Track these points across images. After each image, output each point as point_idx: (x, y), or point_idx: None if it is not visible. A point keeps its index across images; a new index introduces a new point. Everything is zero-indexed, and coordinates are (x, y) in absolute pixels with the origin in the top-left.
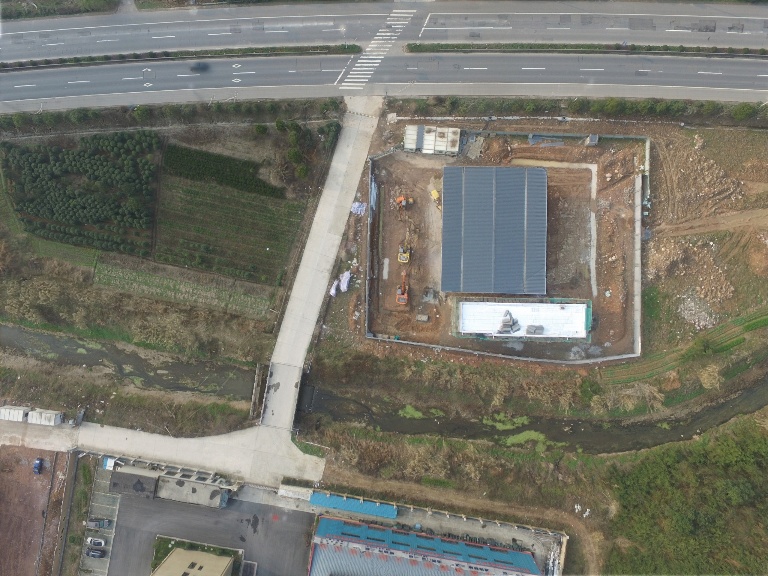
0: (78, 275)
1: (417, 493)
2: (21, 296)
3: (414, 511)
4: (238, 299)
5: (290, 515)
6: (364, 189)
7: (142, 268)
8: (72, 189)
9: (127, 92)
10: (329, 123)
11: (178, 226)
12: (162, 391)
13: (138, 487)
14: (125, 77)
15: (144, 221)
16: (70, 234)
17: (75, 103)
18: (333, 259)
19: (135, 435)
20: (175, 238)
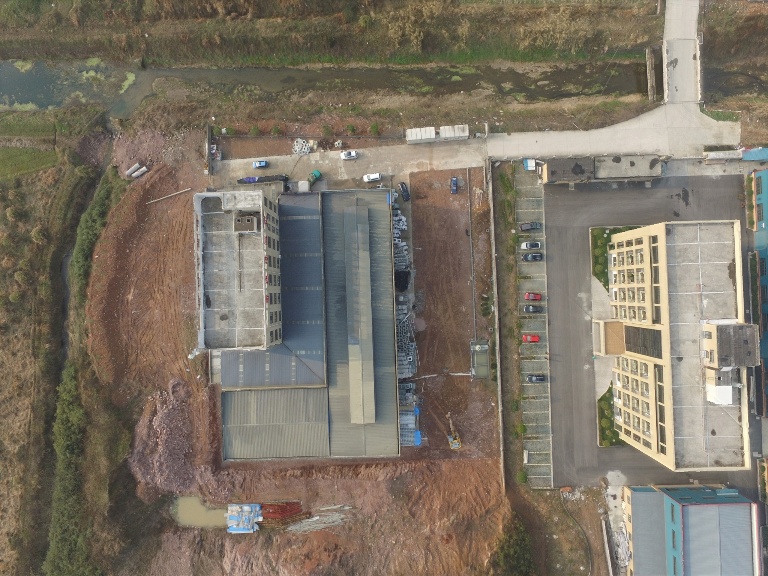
0: None
1: None
2: (400, 20)
3: None
4: None
5: (719, 181)
6: None
7: None
8: None
9: None
10: None
11: None
12: (547, 102)
13: (577, 170)
14: None
15: None
16: None
17: None
18: None
19: (545, 136)
20: None
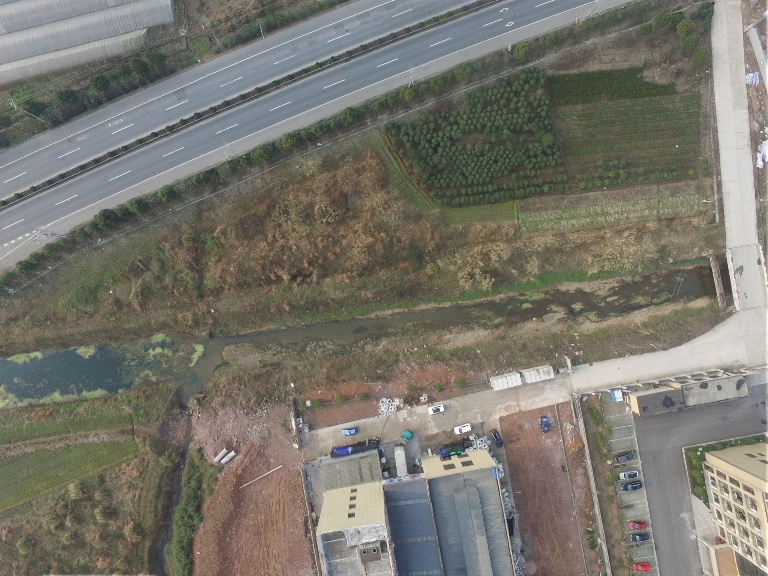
0: (507, 231)
1: None
2: (468, 266)
3: None
4: (667, 202)
5: None
6: (751, 59)
7: (564, 204)
8: (482, 146)
9: (492, 37)
10: (697, 7)
11: (585, 152)
12: (618, 317)
13: (668, 403)
14: (486, 23)
15: (558, 155)
16: (488, 192)
17: (444, 64)
18: (748, 133)
19: (626, 362)
20: (585, 165)
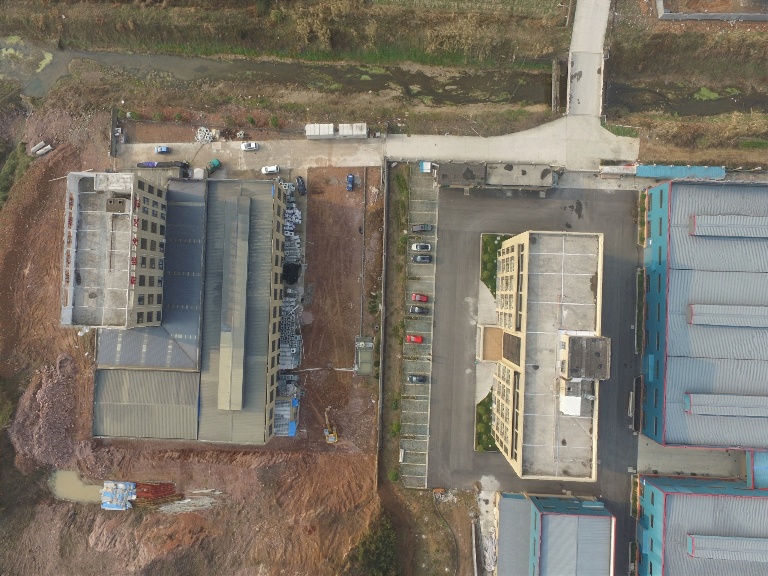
0: None
1: (737, 158)
2: (309, 17)
3: (737, 174)
4: (523, 1)
5: (613, 195)
6: None
7: None
8: None
9: None
10: None
11: None
12: (453, 106)
13: (468, 175)
14: None
15: None
16: None
17: None
18: None
19: (444, 140)
20: None
